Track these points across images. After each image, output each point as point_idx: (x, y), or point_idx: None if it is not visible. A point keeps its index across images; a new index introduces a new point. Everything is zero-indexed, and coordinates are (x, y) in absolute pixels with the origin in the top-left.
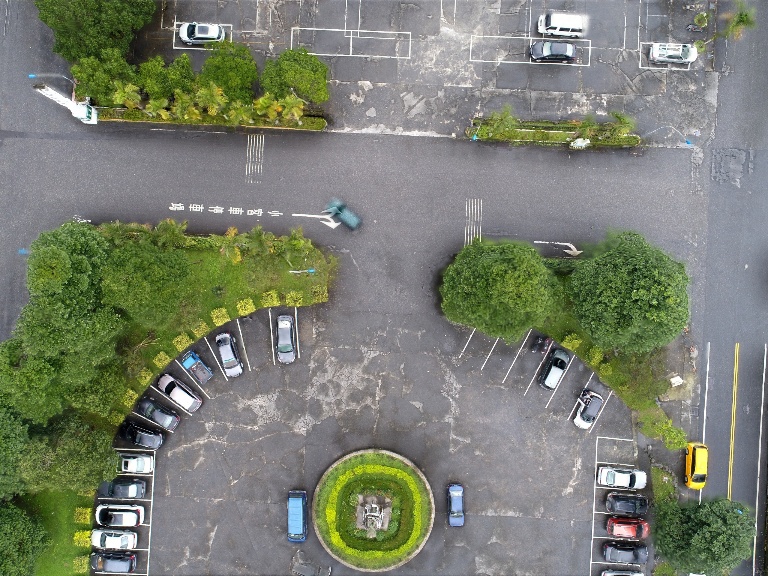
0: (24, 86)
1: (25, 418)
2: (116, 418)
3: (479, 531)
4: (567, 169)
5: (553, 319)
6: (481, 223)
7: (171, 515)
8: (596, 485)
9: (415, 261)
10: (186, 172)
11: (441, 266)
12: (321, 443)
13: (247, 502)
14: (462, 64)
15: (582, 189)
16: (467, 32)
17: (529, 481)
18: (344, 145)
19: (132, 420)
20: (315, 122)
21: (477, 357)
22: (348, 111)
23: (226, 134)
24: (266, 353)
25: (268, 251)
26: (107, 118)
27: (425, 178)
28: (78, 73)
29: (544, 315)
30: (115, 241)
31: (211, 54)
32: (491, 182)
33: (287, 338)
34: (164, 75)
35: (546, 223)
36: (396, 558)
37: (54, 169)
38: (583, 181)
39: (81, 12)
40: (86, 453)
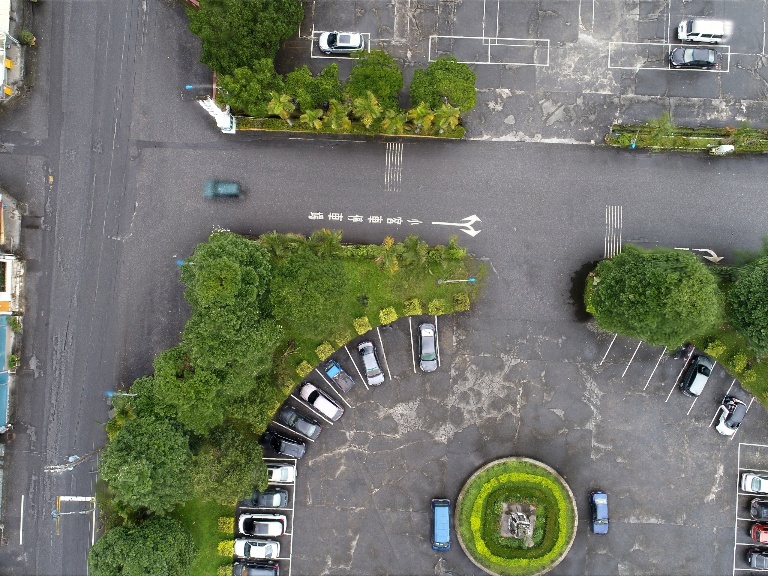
0: (162, 96)
1: (187, 429)
2: (259, 427)
3: (622, 538)
4: (707, 175)
5: (711, 327)
6: (621, 230)
7: (313, 524)
8: (738, 492)
9: (555, 268)
10: (325, 181)
11: (581, 273)
12: (462, 451)
13: (389, 511)
14: (601, 71)
15: (722, 195)
16: (605, 39)
17: (671, 488)
18: (483, 153)
19: (273, 429)
20: (456, 130)
21: (618, 364)
22: (486, 119)
23: (365, 143)
24: (407, 361)
25: (423, 260)
26: (247, 128)
27: (565, 185)
28: (232, 84)
29: (707, 323)
30: (276, 252)
31: (357, 63)
32: (631, 189)
33: (431, 346)
34: (314, 85)
35: (686, 230)
36: (540, 566)
37: (193, 179)
38: (723, 187)
39: (237, 23)
40: (245, 463)
